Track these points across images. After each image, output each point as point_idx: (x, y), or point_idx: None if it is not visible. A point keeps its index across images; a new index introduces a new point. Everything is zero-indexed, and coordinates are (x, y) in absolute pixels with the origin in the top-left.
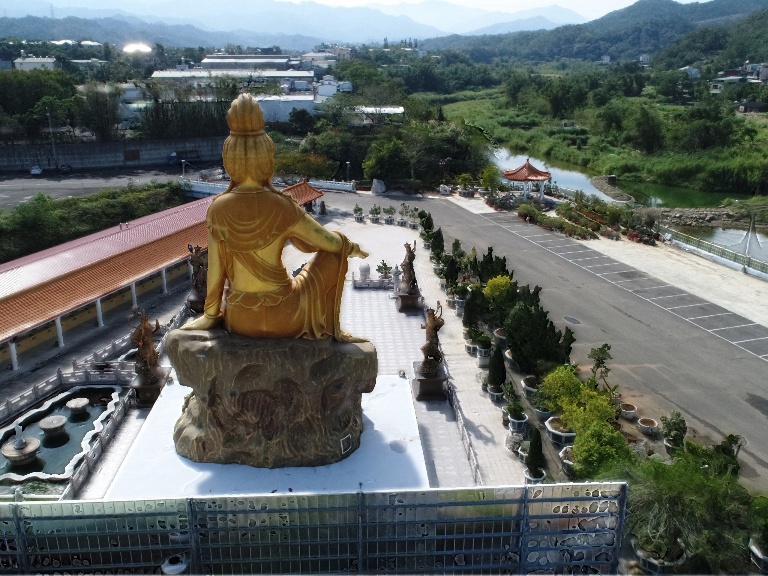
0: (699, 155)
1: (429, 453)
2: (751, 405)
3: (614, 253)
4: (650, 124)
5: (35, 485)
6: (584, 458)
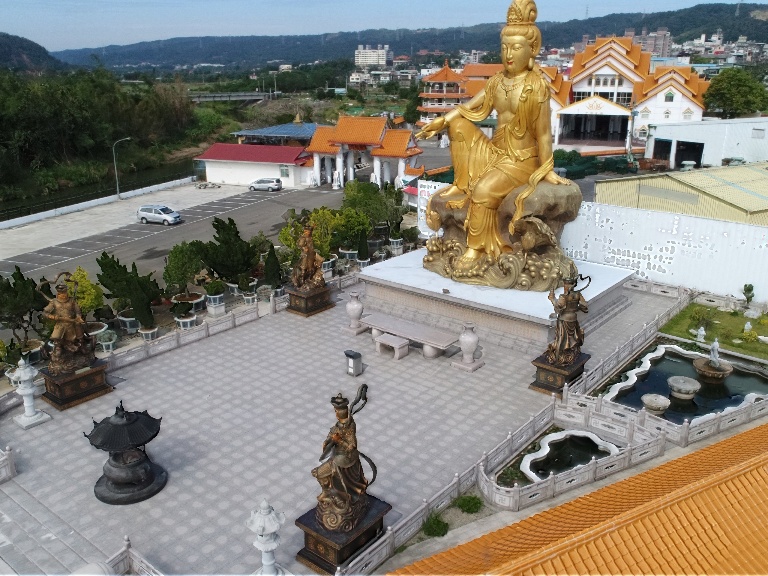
0: None
1: None
2: (159, 257)
3: None
4: None
5: None
6: None
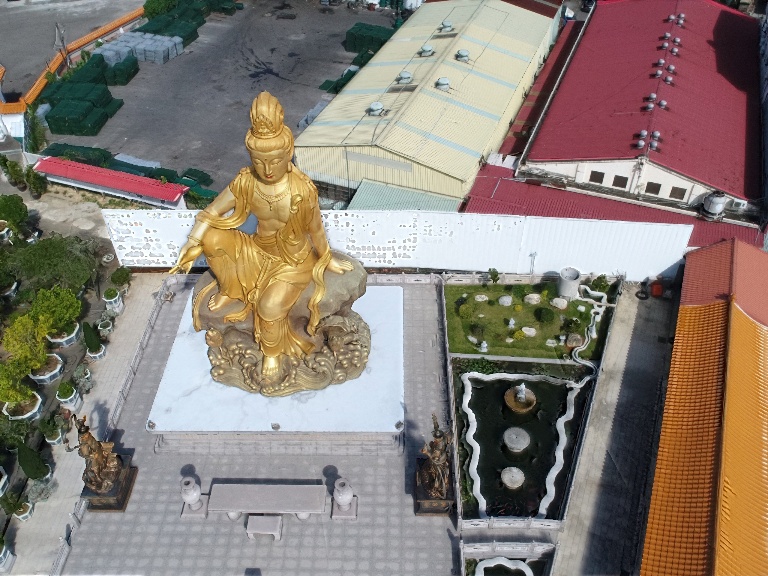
0: None
1: None
2: None
3: None
4: None
5: (486, 369)
6: None
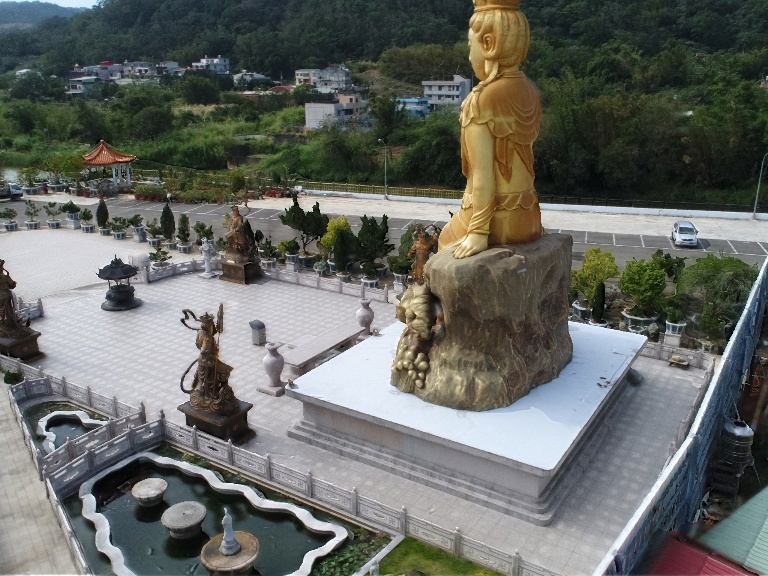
0: (163, 139)
1: None
2: None
3: (284, 207)
4: (93, 116)
5: None
6: (651, 284)
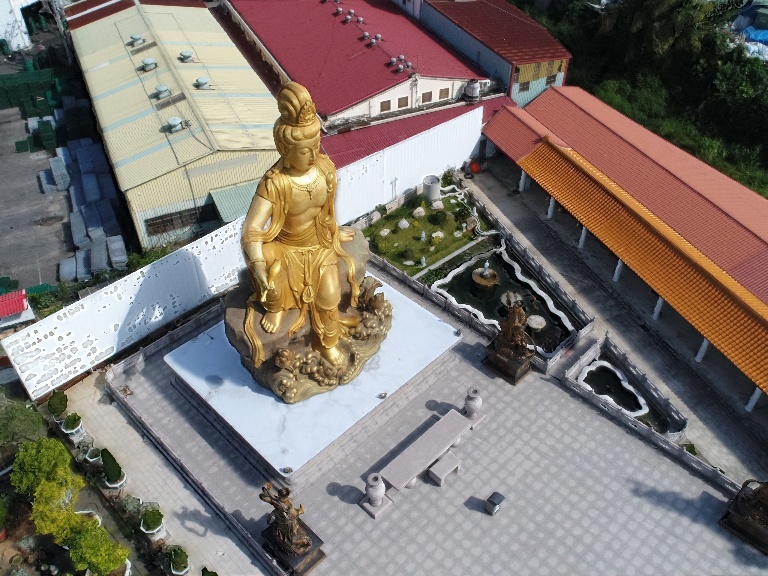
0: None
1: (223, 454)
2: None
3: None
4: None
5: (439, 276)
6: None
